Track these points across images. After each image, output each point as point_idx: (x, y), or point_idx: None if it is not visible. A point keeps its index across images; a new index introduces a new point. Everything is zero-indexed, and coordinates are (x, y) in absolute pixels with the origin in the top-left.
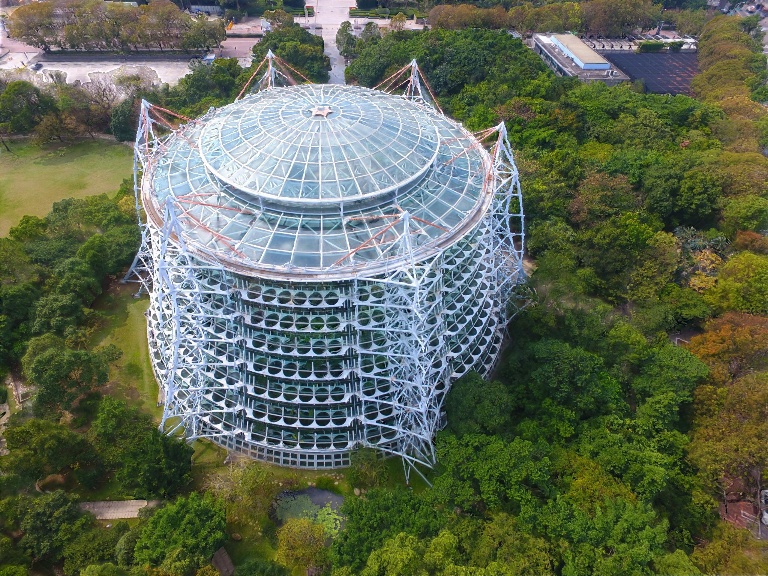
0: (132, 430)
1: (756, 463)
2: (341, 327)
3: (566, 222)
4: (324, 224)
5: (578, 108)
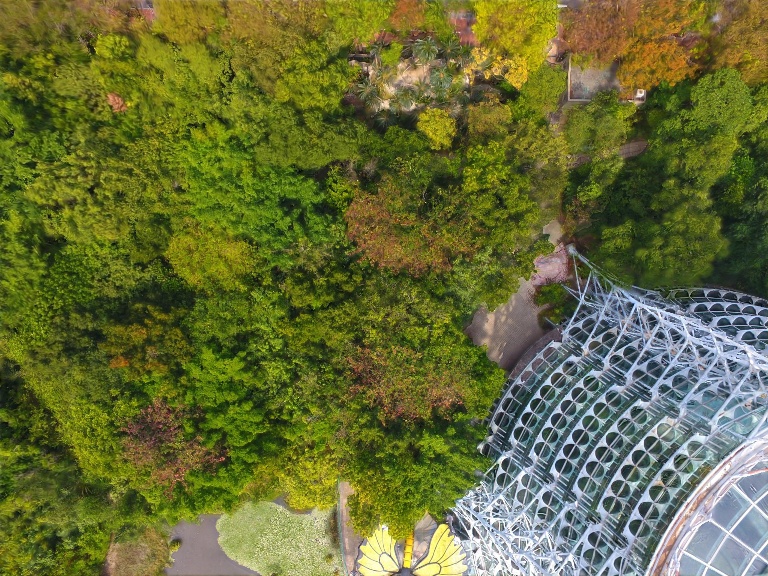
0: None
1: None
2: None
3: None
4: None
5: (70, 326)
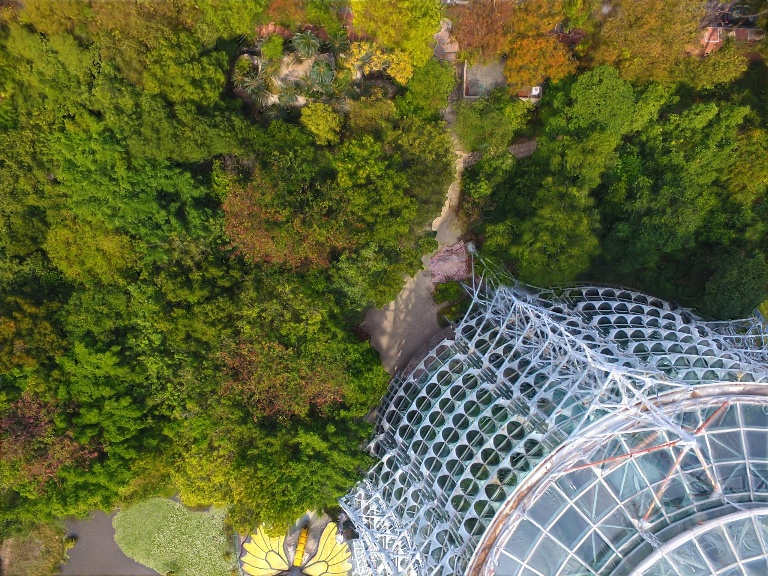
0: None
1: None
2: None
3: (330, 263)
4: None
5: None
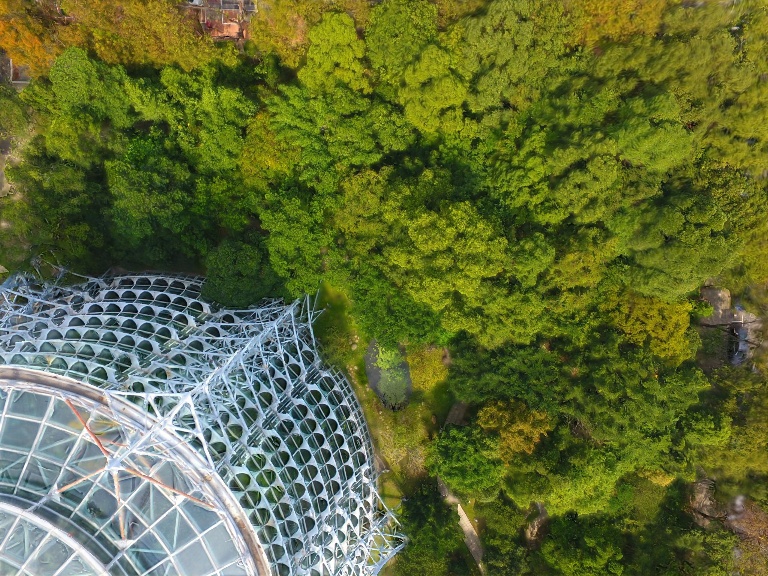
0: (415, 570)
1: (173, 7)
2: (257, 451)
3: None
4: (147, 567)
5: None
